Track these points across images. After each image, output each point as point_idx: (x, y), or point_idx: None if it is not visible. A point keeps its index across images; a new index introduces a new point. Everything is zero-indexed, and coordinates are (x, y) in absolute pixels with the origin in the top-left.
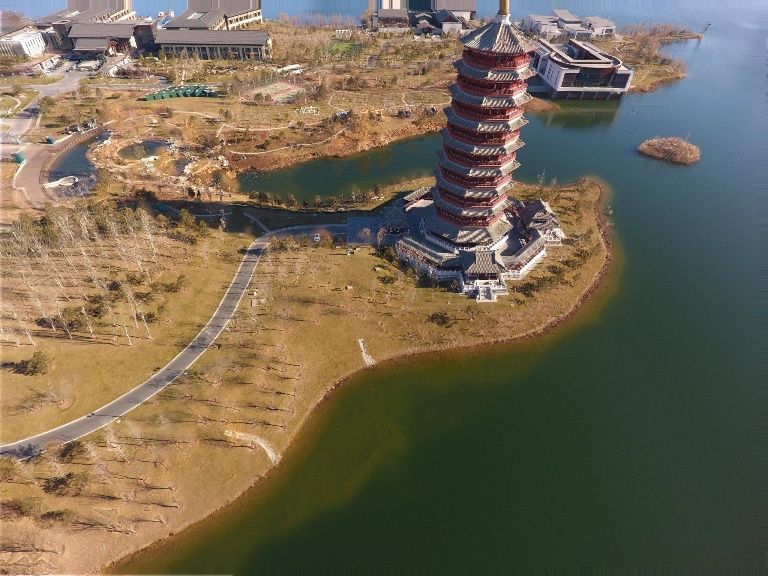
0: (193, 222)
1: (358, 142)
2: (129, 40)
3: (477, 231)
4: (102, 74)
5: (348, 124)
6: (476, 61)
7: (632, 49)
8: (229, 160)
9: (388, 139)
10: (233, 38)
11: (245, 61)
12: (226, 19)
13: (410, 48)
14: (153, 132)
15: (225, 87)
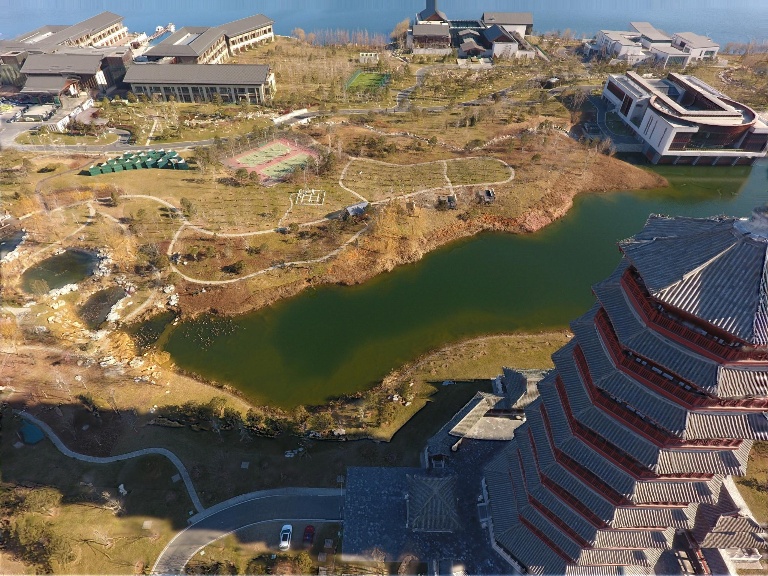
0: (67, 486)
1: (377, 256)
2: (95, 76)
3: (602, 567)
4: (48, 128)
5: (364, 224)
6: (677, 330)
7: (744, 79)
8: (180, 294)
9: (422, 248)
10: (223, 75)
11: (238, 104)
12: (227, 39)
13: (453, 81)
14: (84, 233)
15: (199, 154)
